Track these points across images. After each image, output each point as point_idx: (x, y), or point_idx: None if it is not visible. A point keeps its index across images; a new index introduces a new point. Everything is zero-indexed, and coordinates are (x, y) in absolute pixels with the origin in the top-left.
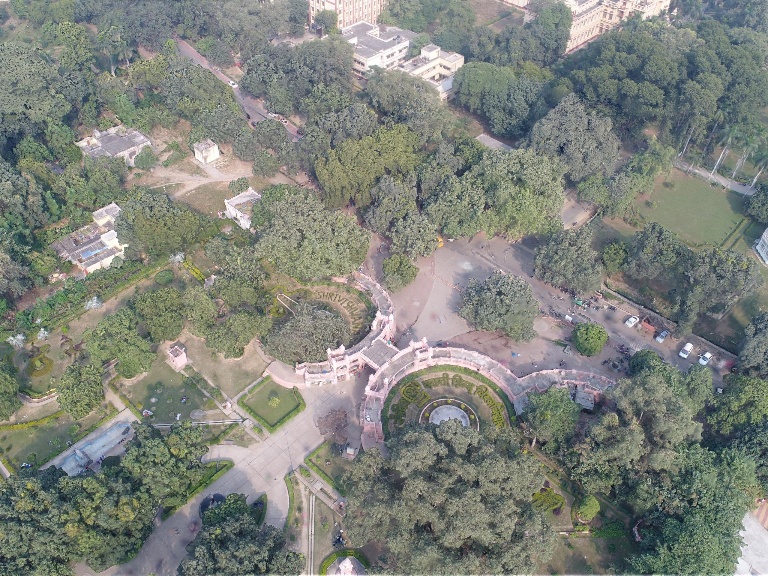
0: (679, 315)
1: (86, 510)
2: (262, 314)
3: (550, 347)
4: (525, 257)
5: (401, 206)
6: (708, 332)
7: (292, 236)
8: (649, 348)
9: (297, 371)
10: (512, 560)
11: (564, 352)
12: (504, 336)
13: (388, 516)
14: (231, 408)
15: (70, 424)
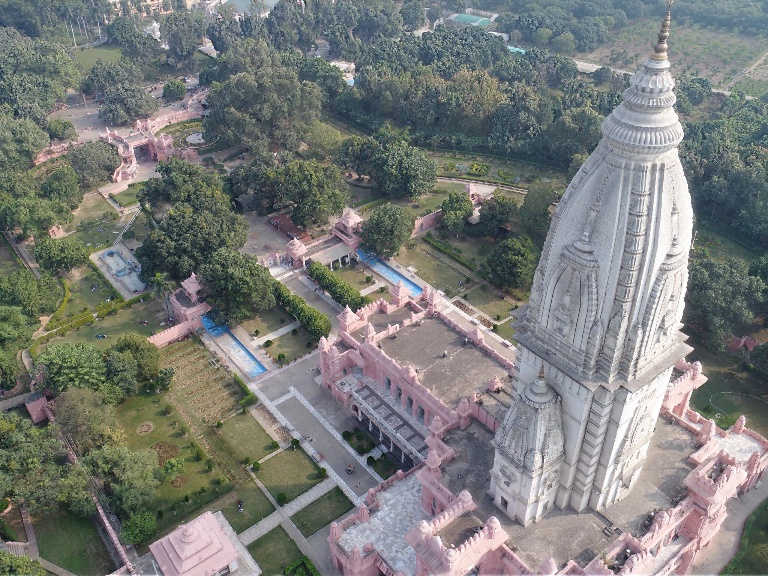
0: (188, 55)
1: (209, 187)
2: (43, 195)
3: (168, 108)
4: (85, 106)
5: (5, 110)
6: (194, 71)
7: (5, 130)
8: (192, 85)
9: (118, 179)
10: (310, 84)
11: (175, 105)
12: (147, 119)
13: (269, 109)
14: (126, 211)
15: (81, 283)
